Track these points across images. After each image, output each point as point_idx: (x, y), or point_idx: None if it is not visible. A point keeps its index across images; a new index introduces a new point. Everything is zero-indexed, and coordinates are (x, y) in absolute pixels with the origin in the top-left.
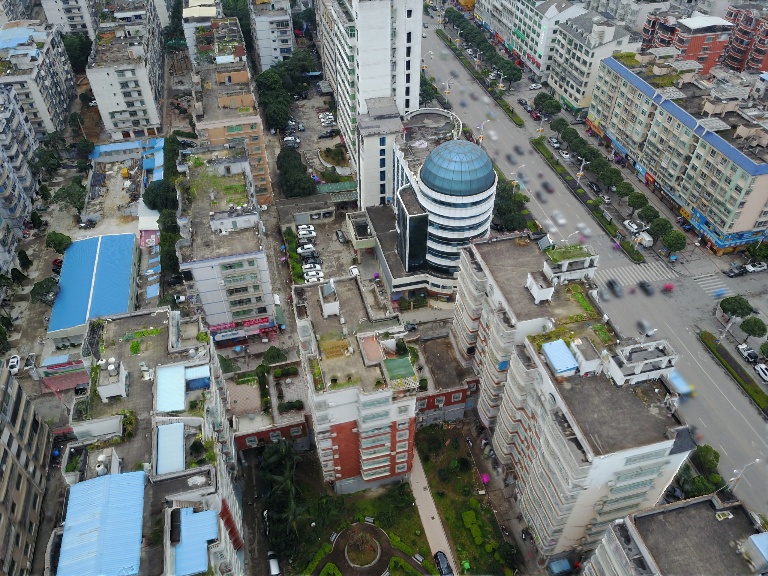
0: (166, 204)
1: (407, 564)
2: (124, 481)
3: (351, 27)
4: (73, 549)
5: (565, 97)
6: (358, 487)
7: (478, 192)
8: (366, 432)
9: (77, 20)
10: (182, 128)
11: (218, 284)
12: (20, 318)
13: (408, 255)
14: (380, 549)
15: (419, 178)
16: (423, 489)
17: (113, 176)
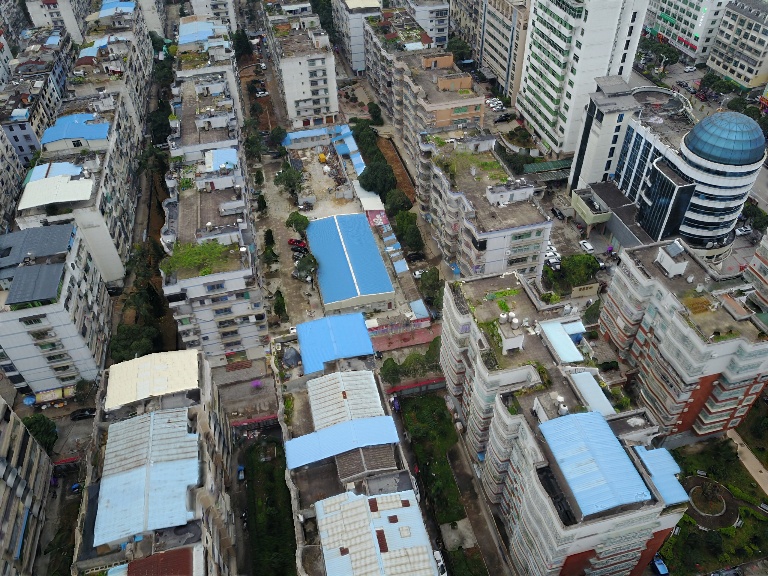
0: (384, 185)
1: (758, 513)
2: (589, 420)
3: (579, 8)
4: (579, 478)
5: (731, 78)
6: (680, 443)
7: (755, 161)
8: (734, 384)
9: (222, 16)
10: (360, 115)
11: (503, 254)
12: None
13: (665, 226)
14: (724, 500)
15: (687, 150)
16: (740, 445)
17: (309, 162)
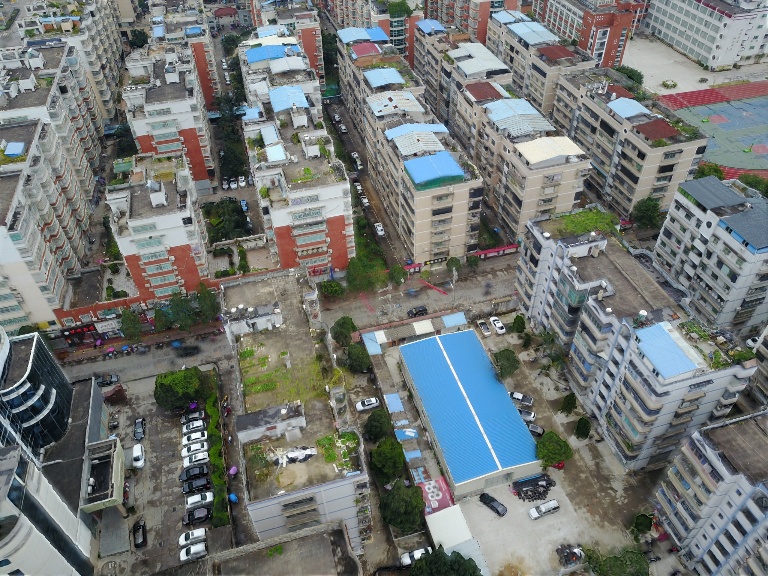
0: None
1: None
2: None
3: None
4: None
5: None
6: None
7: None
8: None
9: None
10: None
11: None
12: None
13: None
14: None
15: None
16: None
17: None
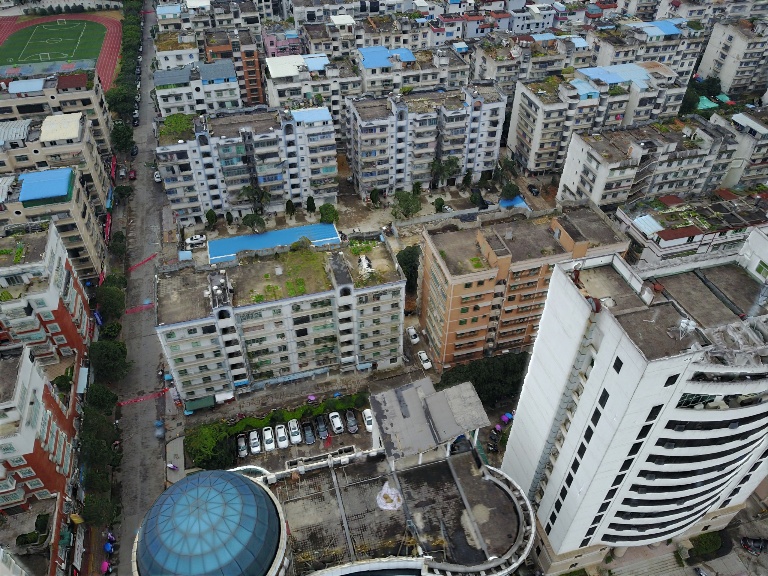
0: None
1: None
2: None
3: None
4: None
5: None
6: None
7: None
8: None
9: None
10: None
11: None
12: None
13: None
14: None
15: None
16: None
17: None
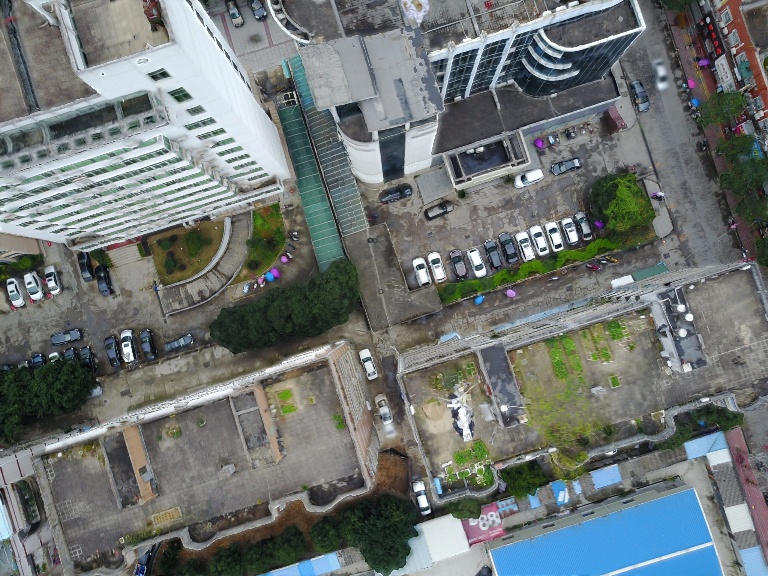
0: None
1: None
2: None
3: None
4: None
5: None
6: None
7: None
8: None
9: None
10: None
11: None
12: None
13: None
14: None
15: None
16: None
17: None
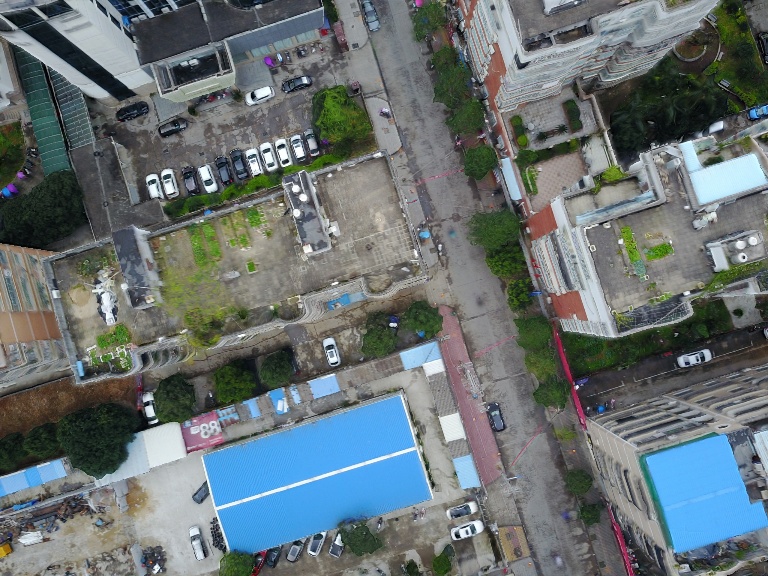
0: (122, 428)
1: None
2: None
3: None
4: None
5: None
6: None
7: None
8: None
9: None
10: None
11: None
12: (377, 568)
13: None
14: None
15: None
16: None
17: (3, 575)
